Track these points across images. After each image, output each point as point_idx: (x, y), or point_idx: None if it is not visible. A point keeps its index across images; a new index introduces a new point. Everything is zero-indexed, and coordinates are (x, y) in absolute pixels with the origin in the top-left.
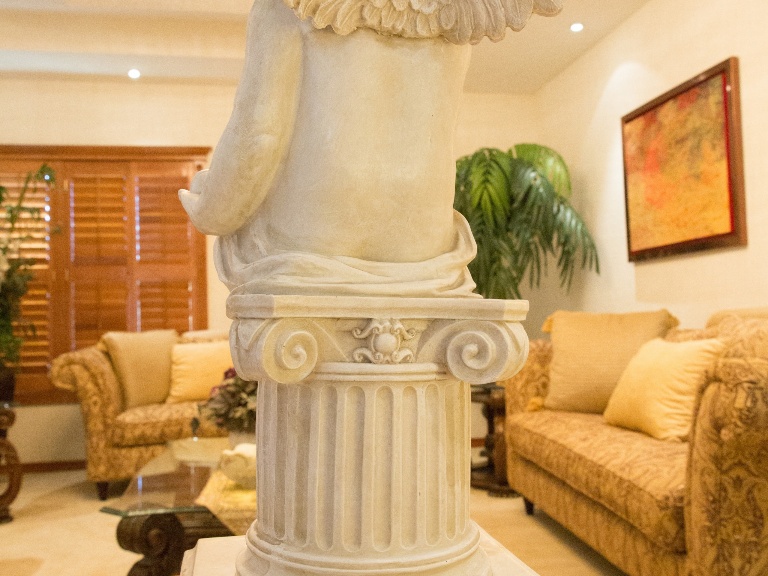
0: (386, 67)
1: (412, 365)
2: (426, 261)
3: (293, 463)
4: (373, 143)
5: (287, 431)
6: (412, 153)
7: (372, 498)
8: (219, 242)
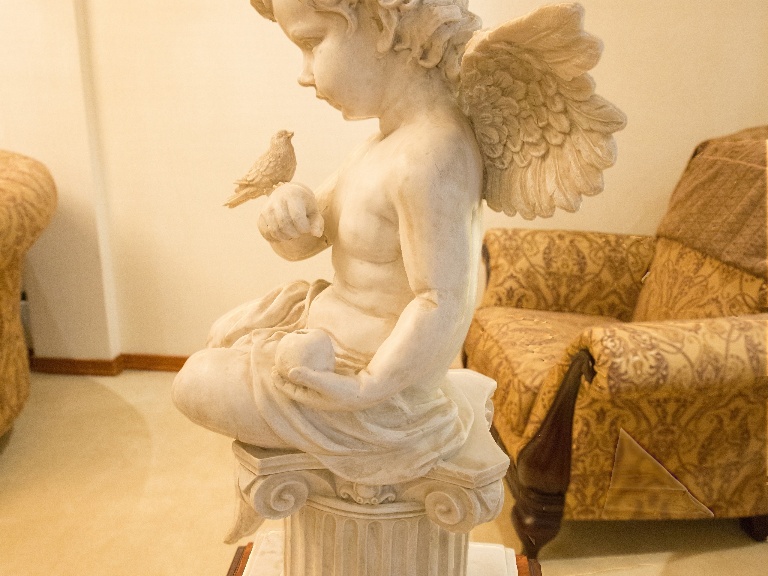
0: None
1: None
2: None
3: (436, 572)
4: None
5: (430, 552)
6: None
7: None
8: (296, 408)
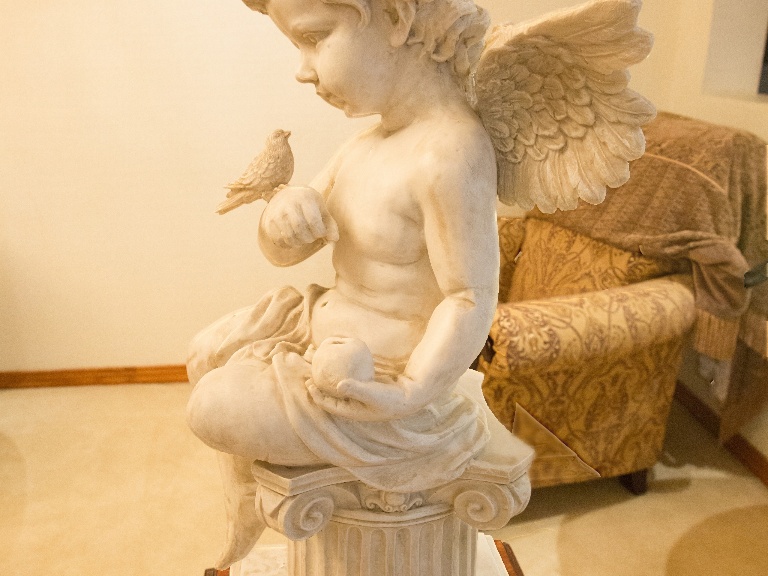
0: None
1: None
2: None
3: None
4: None
5: None
6: None
7: None
8: (332, 421)
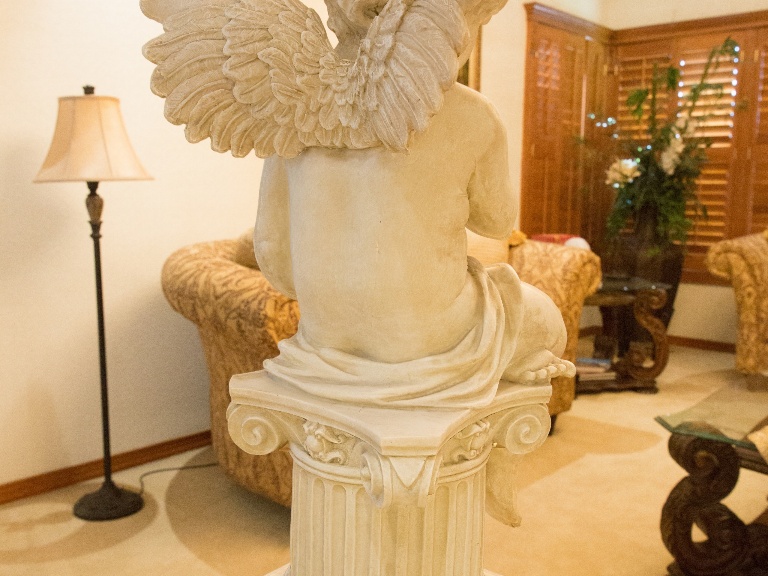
0: (335, 181)
1: (338, 468)
2: (399, 364)
3: None
4: (325, 255)
5: None
6: (360, 265)
7: (311, 567)
8: None
